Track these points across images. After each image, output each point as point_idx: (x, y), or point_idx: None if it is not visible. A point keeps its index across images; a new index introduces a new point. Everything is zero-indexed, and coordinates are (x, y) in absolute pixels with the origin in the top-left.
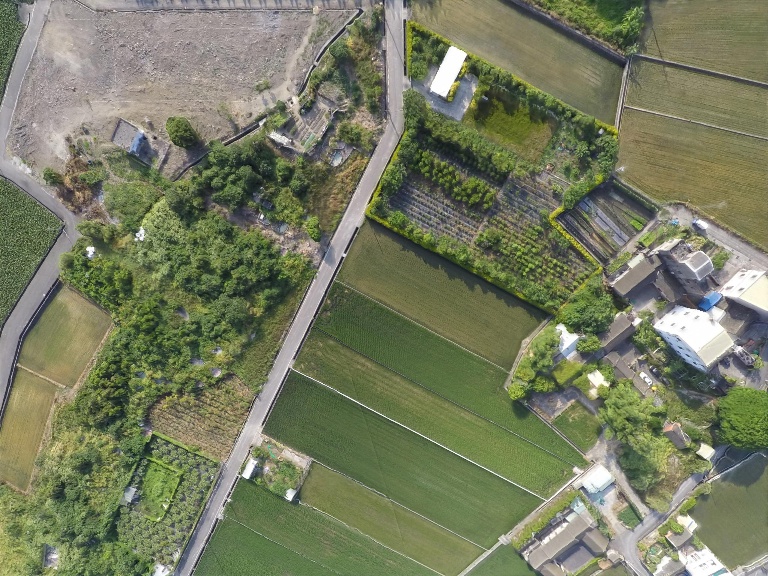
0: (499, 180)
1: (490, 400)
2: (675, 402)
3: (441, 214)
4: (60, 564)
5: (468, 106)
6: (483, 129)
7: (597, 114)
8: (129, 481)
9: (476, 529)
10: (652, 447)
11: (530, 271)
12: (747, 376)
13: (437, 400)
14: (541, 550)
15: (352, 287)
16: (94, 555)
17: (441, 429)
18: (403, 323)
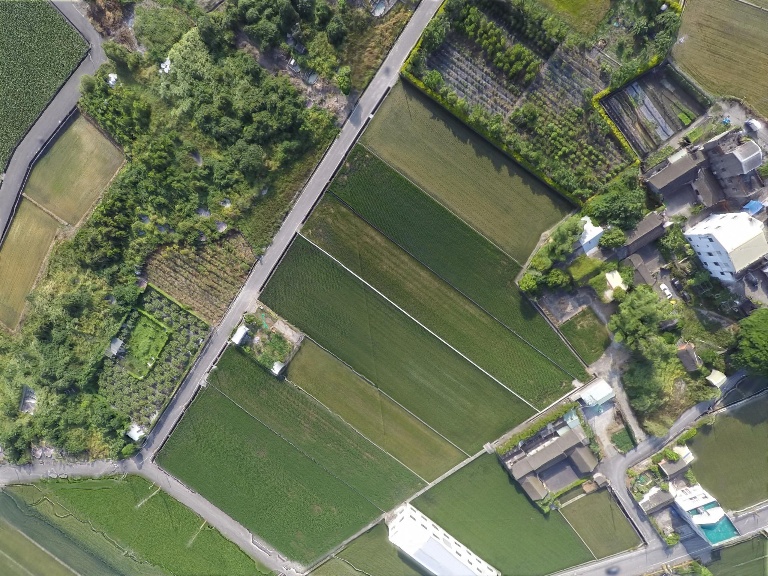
0: (546, 50)
1: (498, 294)
2: (692, 321)
3: (479, 82)
4: (37, 408)
5: None
6: None
7: None
8: (117, 331)
9: (462, 432)
10: (664, 350)
11: (563, 156)
12: None
13: (443, 287)
14: (526, 461)
15: (374, 152)
16: (72, 405)
17: (442, 320)
18: (421, 197)
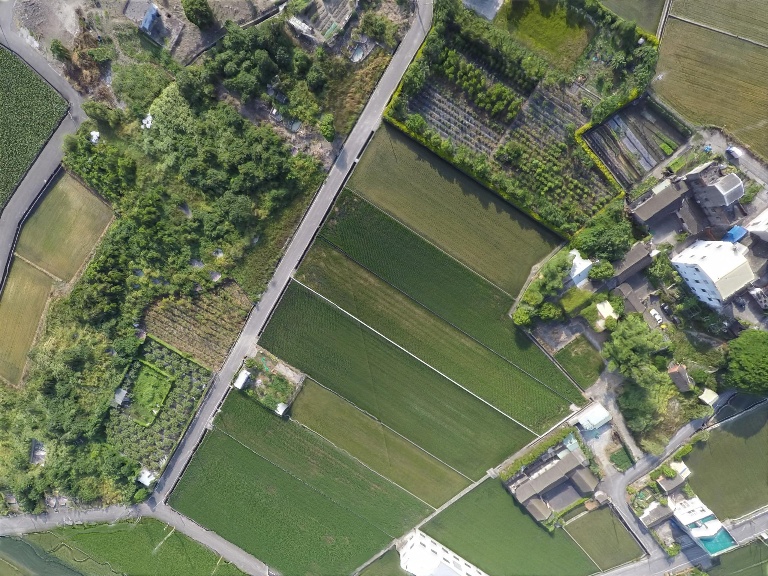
0: (526, 88)
1: (493, 327)
2: (683, 343)
3: (462, 122)
4: (47, 460)
5: (502, 4)
6: (515, 31)
7: (638, 23)
8: (120, 382)
9: (465, 460)
10: (656, 378)
11: (549, 191)
12: (761, 322)
13: (438, 323)
14: (529, 484)
15: (362, 196)
16: (81, 455)
17: (440, 354)
18: (411, 238)
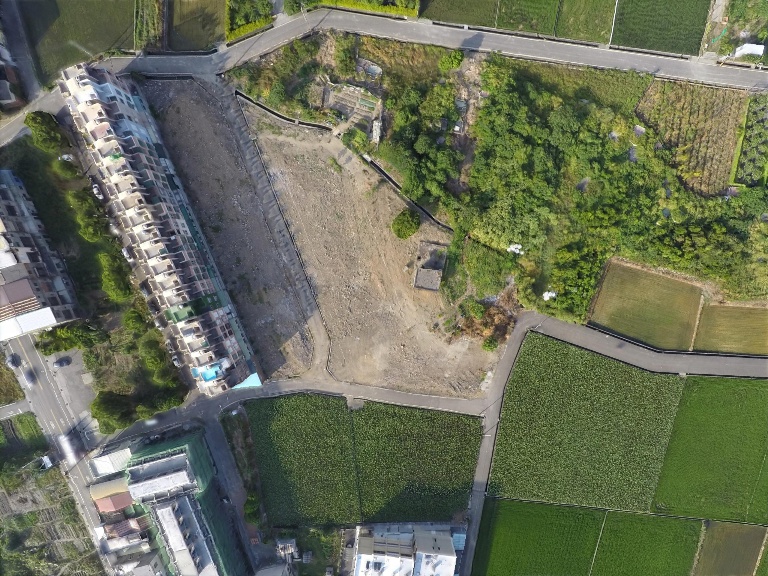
0: None
1: None
2: None
3: None
4: None
5: None
6: None
7: None
8: None
9: None
10: None
11: None
12: None
13: None
14: None
15: (497, 6)
16: None
17: None
18: None
